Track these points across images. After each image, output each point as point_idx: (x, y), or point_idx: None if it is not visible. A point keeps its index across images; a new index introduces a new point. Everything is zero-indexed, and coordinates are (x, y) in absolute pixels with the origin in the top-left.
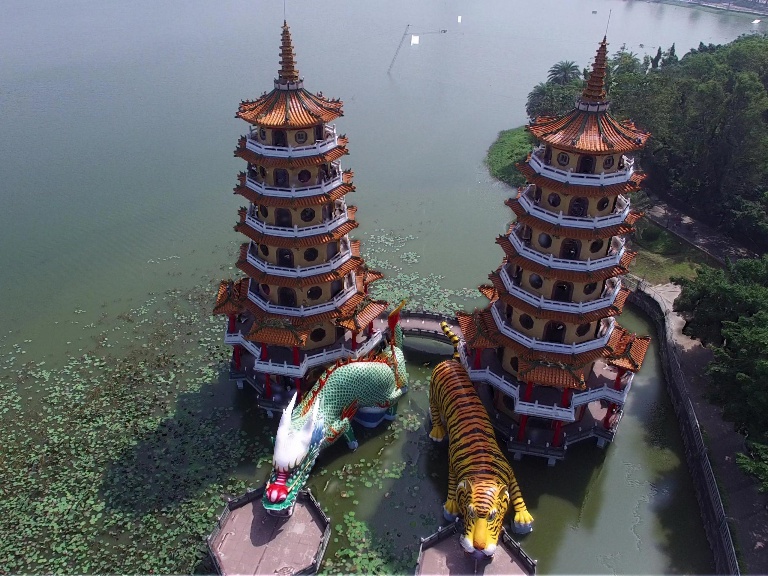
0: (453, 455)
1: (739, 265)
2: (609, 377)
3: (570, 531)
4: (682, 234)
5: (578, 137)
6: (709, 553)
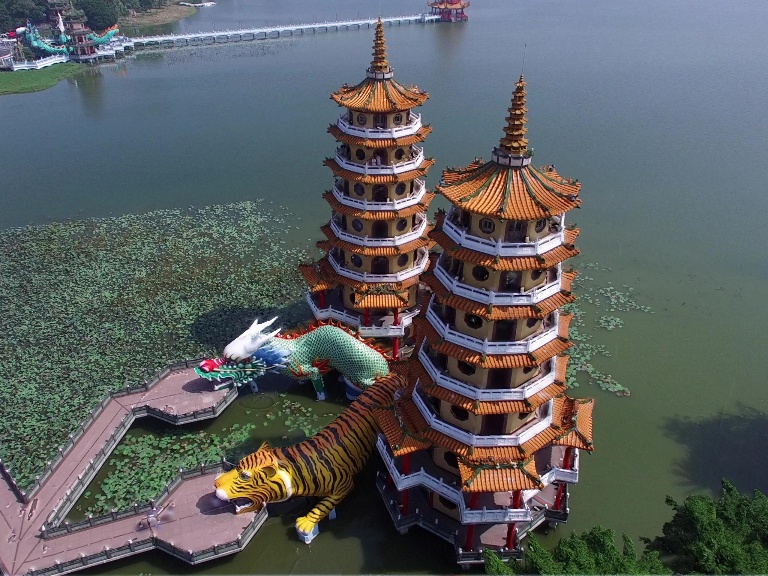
0: None
1: None
2: (497, 498)
3: None
4: None
5: (460, 182)
6: None
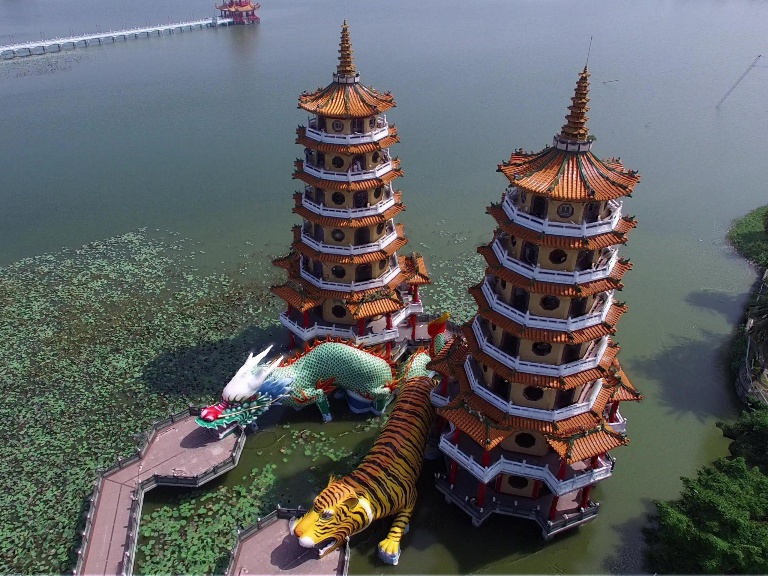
0: None
1: None
2: (573, 465)
3: None
4: None
5: (530, 173)
6: None
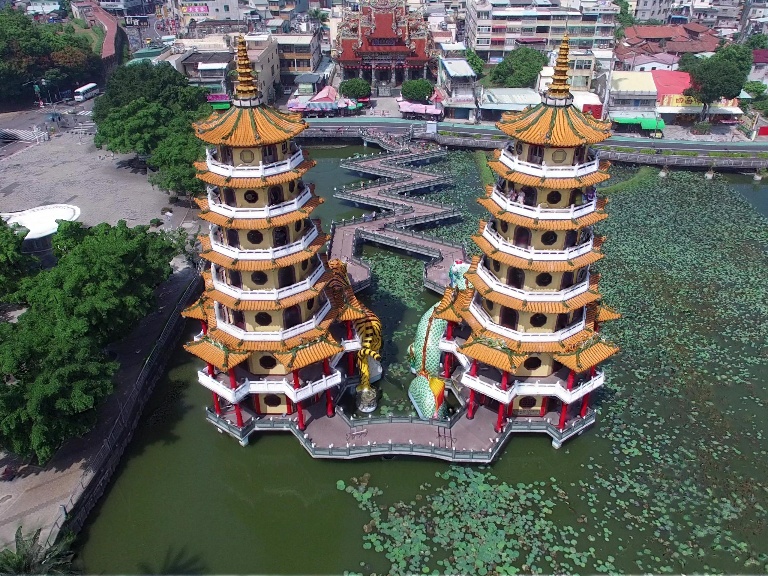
0: None
1: None
2: None
3: None
4: None
5: None
6: None
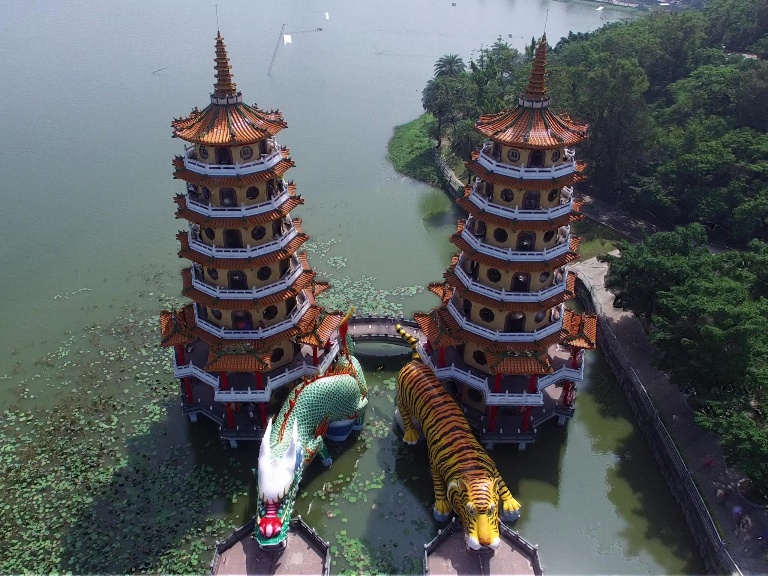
0: (436, 456)
1: (658, 238)
2: (563, 357)
3: (552, 510)
4: (587, 213)
5: (528, 133)
6: (677, 507)
